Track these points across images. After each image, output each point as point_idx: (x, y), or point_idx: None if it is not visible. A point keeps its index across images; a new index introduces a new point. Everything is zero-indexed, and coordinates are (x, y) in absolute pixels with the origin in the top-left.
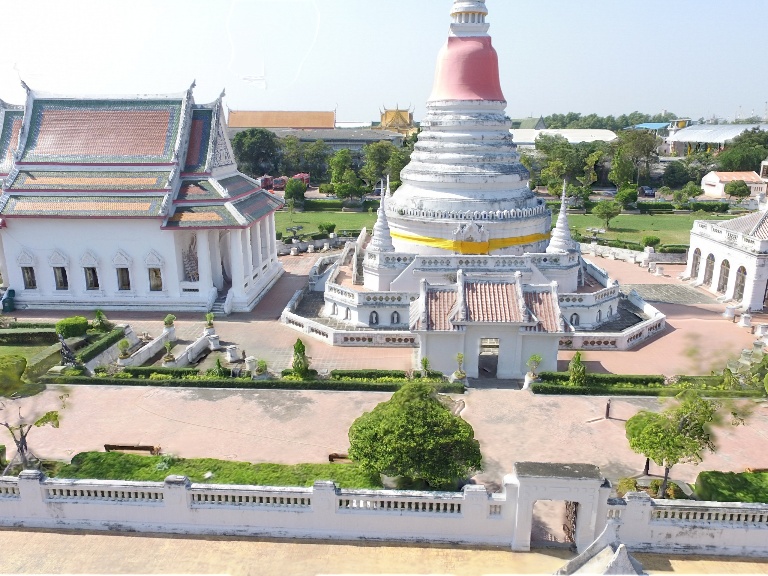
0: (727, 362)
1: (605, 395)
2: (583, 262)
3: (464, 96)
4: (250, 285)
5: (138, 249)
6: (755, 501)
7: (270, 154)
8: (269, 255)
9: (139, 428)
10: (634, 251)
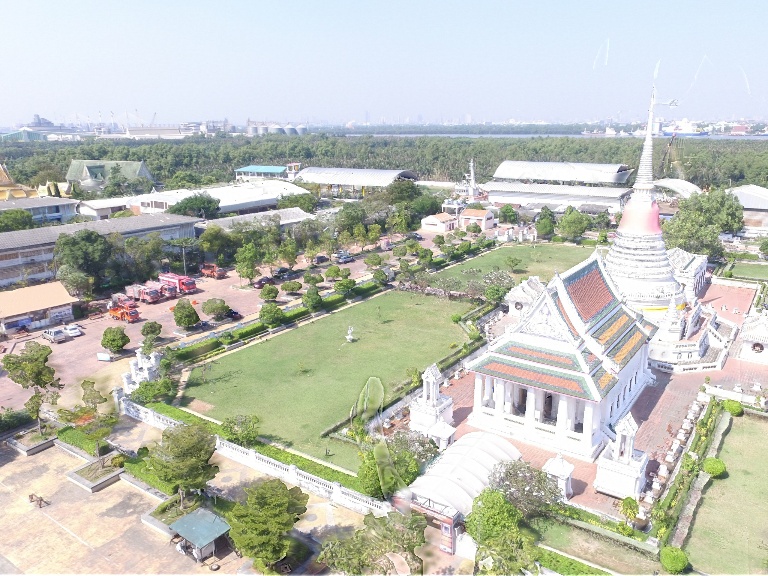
0: None
1: None
2: None
3: None
4: None
5: None
6: None
7: None
8: None
9: None
10: None
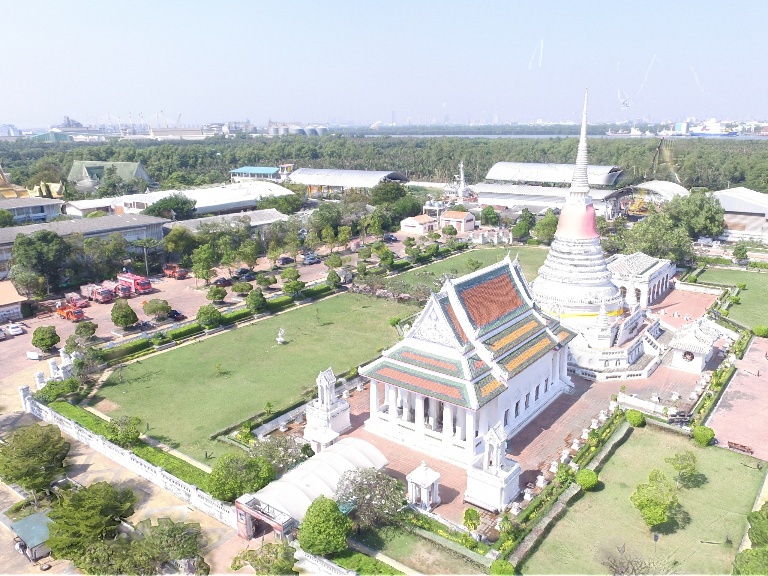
0: None
1: (744, 352)
2: None
3: (596, 236)
4: None
5: None
6: None
7: None
8: None
9: (760, 421)
10: None
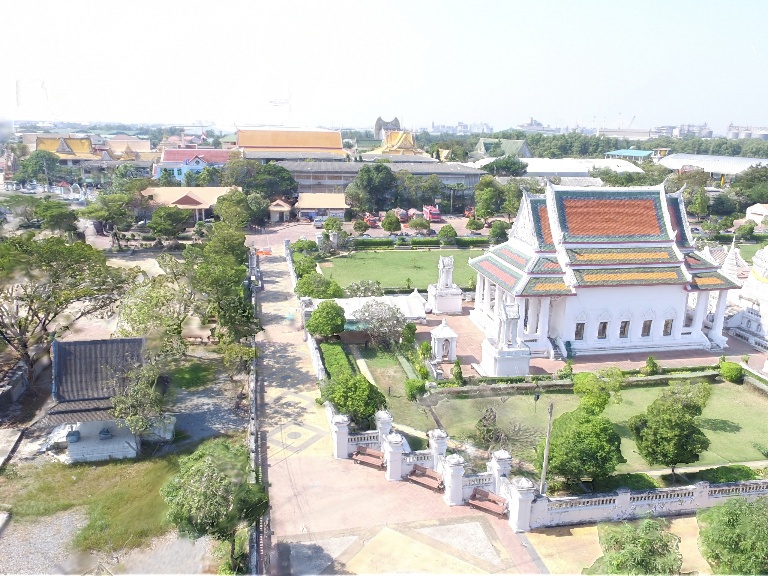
0: None
1: None
2: None
3: None
4: None
5: (661, 306)
6: None
7: (387, 187)
8: None
9: None
10: None
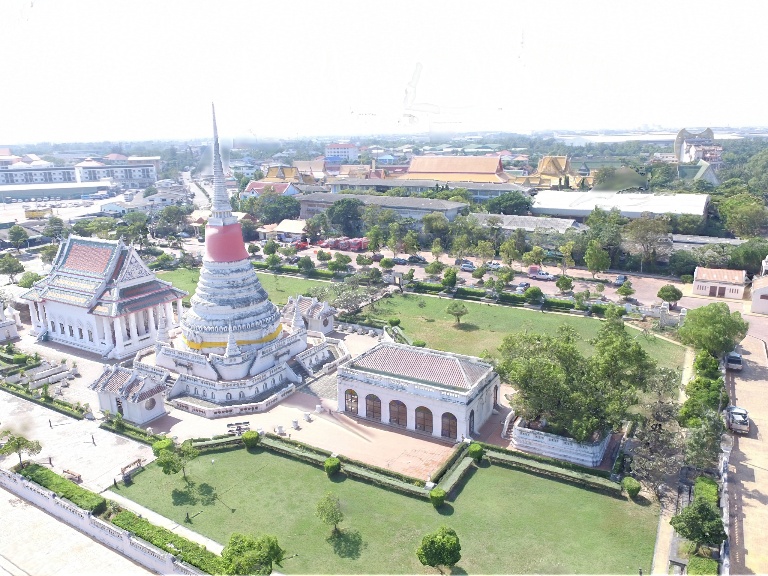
0: (212, 434)
1: None
2: (297, 359)
3: (208, 259)
4: (134, 344)
5: (85, 320)
6: (24, 474)
7: (358, 218)
8: (170, 325)
9: None
10: None
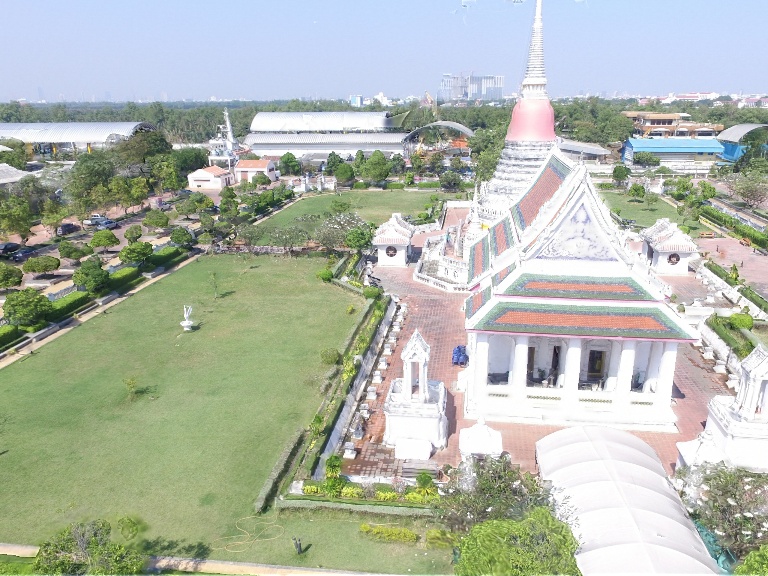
0: None
1: None
2: None
3: None
4: None
5: None
6: None
7: None
8: None
9: None
10: (432, 224)
